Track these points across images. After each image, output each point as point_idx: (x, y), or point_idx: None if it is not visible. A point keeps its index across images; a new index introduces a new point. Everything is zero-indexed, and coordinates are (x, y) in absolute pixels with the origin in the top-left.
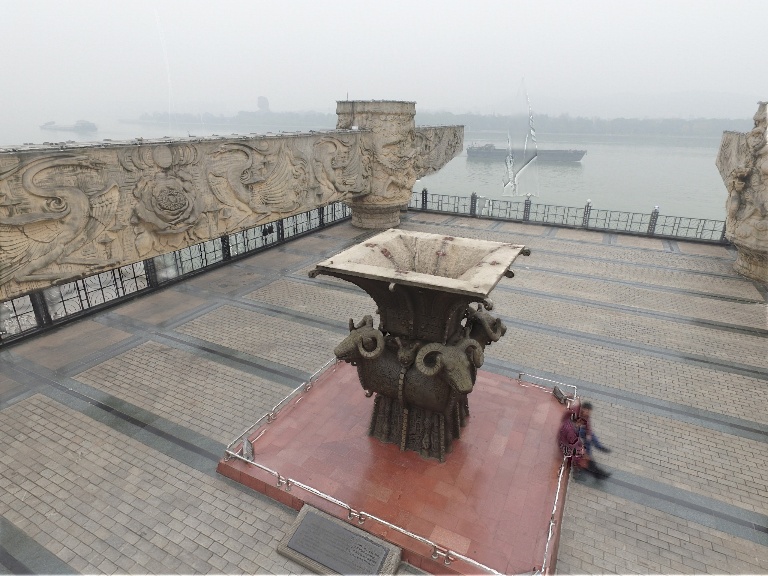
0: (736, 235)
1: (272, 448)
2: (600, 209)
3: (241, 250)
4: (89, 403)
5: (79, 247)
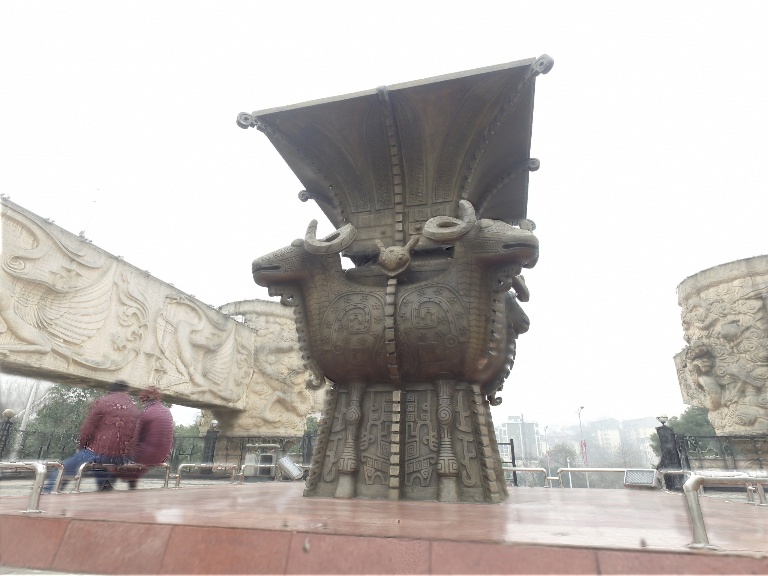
0: None
1: None
2: None
3: None
4: None
5: None
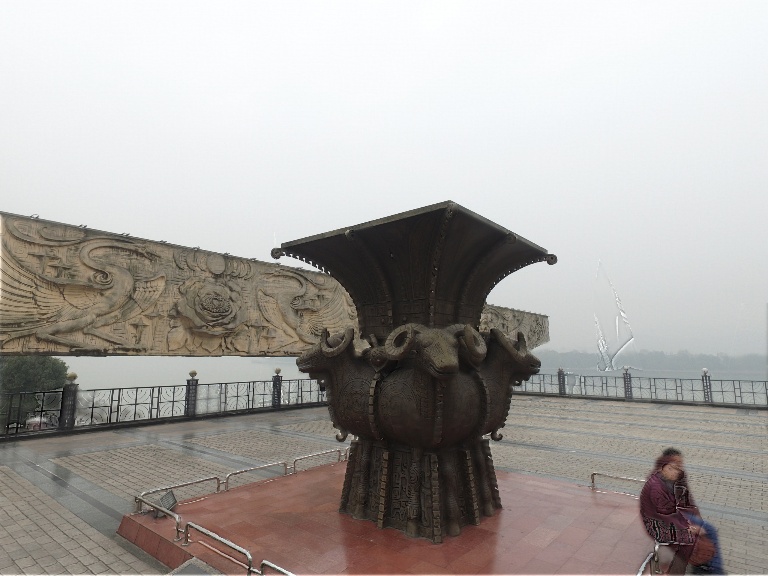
0: None
1: (200, 510)
2: (723, 379)
3: (293, 400)
4: (43, 474)
5: (110, 323)
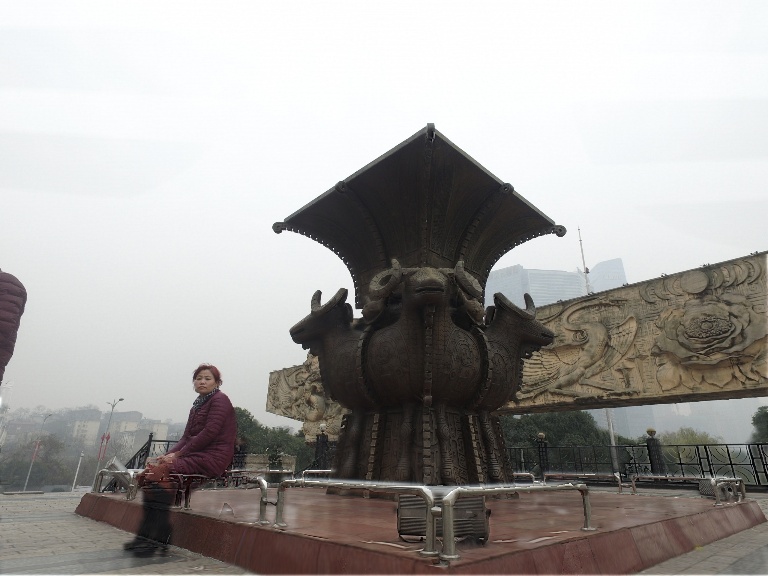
0: None
1: None
2: None
3: None
4: None
5: (597, 372)
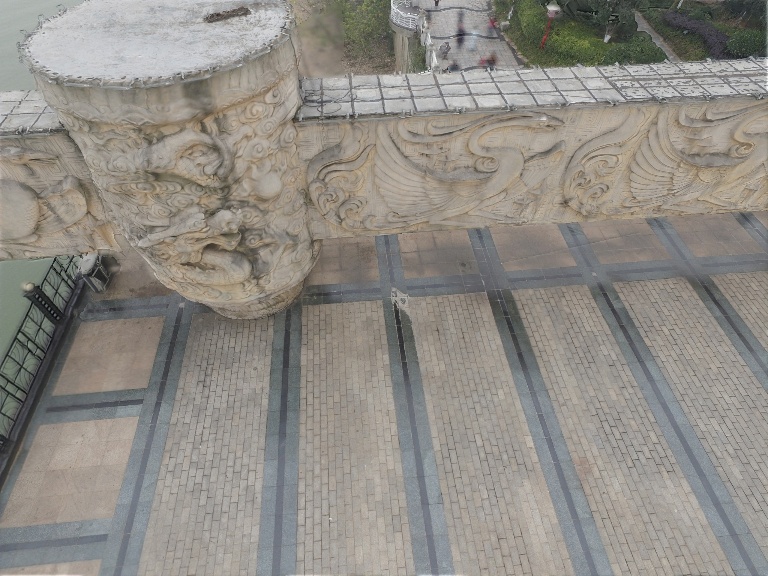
0: (272, 291)
1: None
2: None
3: None
4: None
5: None
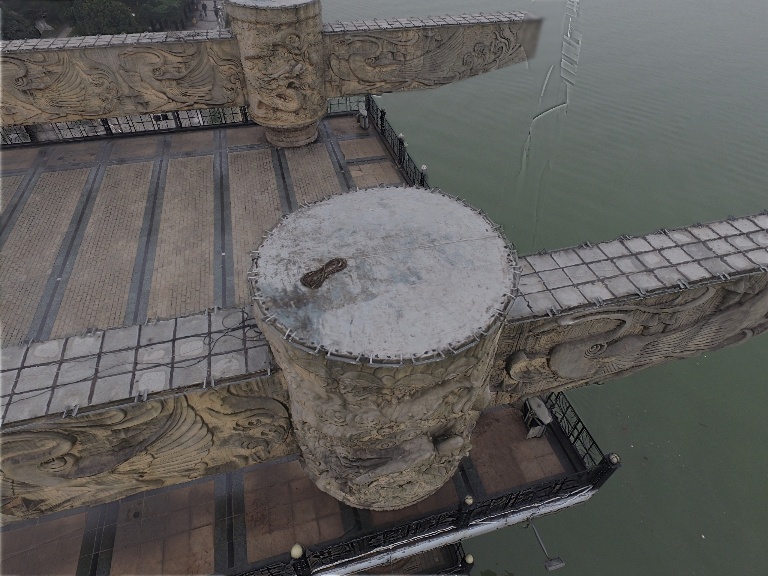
0: None
1: None
2: None
3: (127, 129)
4: None
5: None
